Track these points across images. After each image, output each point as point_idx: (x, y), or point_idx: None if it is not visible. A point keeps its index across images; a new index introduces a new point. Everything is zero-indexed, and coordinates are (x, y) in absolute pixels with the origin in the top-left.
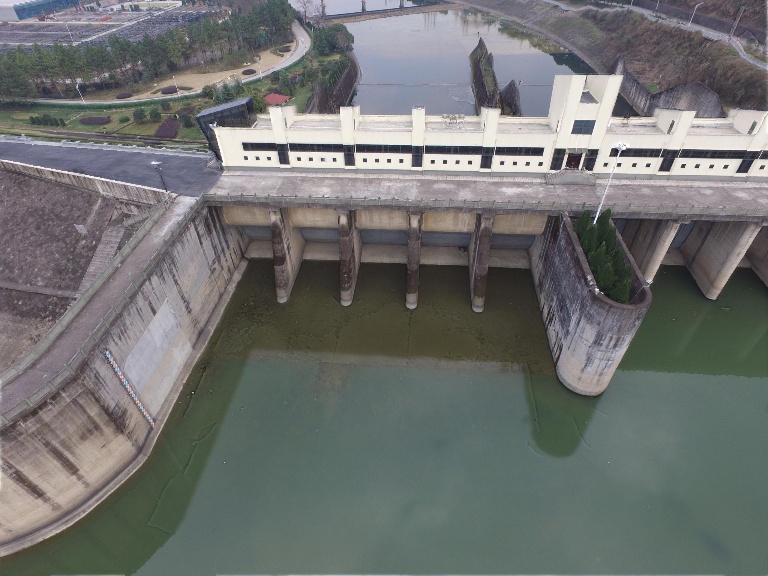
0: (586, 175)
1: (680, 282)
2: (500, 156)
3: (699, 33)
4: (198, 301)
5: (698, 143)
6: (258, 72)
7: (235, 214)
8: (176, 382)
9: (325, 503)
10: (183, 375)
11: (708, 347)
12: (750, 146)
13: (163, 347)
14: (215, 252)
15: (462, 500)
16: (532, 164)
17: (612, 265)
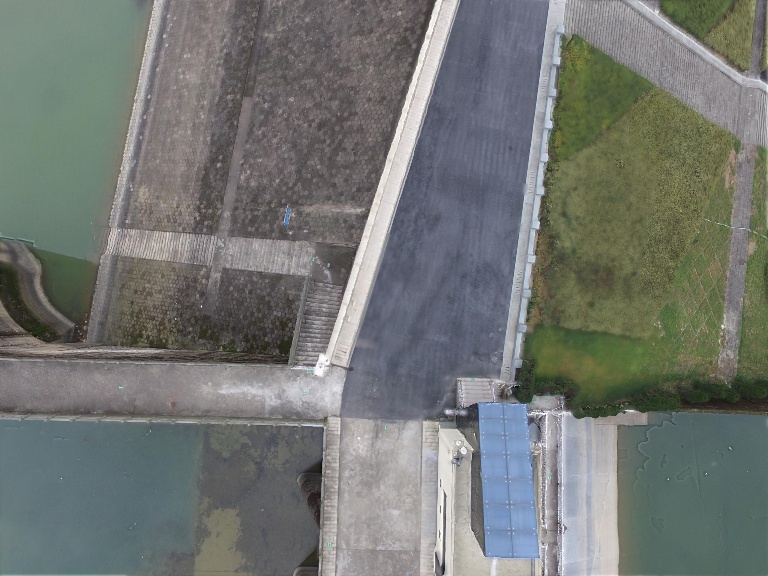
0: None
1: None
2: None
3: None
4: None
5: None
6: None
7: None
8: None
9: None
10: None
11: None
12: None
13: None
14: None
15: None
16: None
17: None
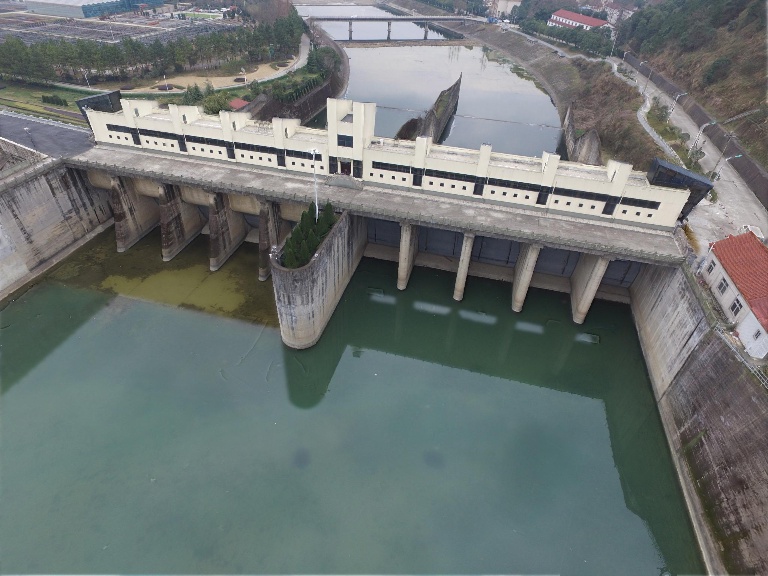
0: (354, 181)
1: (442, 284)
2: (291, 157)
3: (636, 89)
4: (44, 237)
5: (437, 165)
6: (248, 81)
7: (96, 178)
8: (3, 291)
9: (53, 382)
10: (12, 287)
11: (471, 346)
12: (477, 172)
13: None
14: (73, 204)
15: (148, 397)
16: (316, 167)
17: (307, 243)
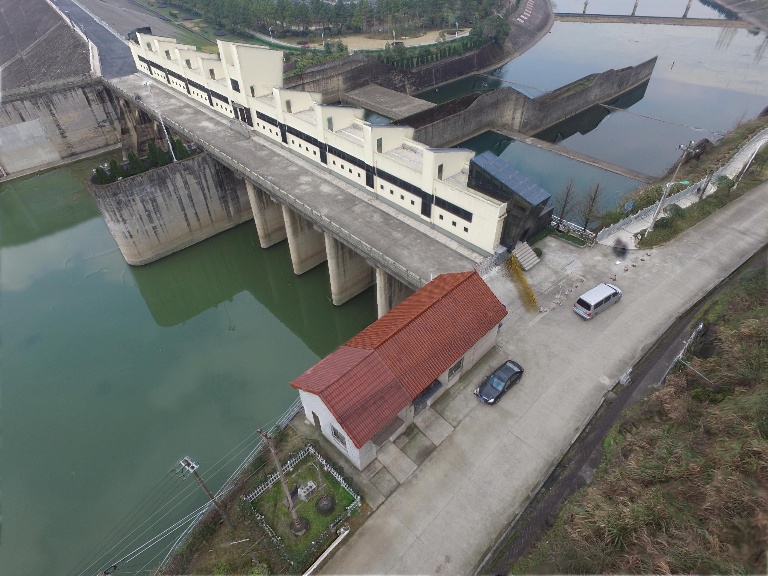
0: (244, 128)
1: None
2: (214, 98)
3: None
4: (77, 136)
5: (292, 122)
6: None
7: None
8: (37, 167)
9: None
10: (44, 166)
11: (320, 331)
12: (318, 136)
13: (29, 142)
14: (108, 116)
15: (20, 260)
16: (228, 110)
17: None
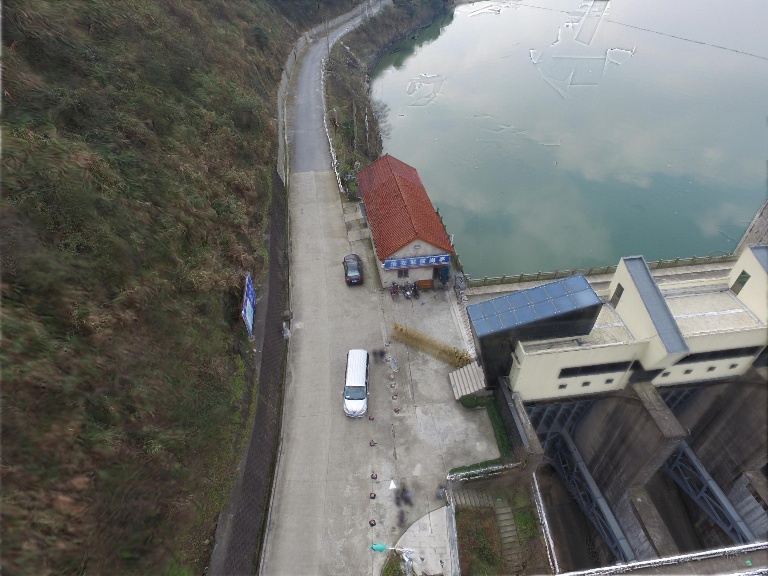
0: None
1: None
2: None
3: None
4: None
5: None
6: None
7: None
8: None
9: None
10: None
11: None
12: None
13: None
14: None
15: None
16: None
17: None
